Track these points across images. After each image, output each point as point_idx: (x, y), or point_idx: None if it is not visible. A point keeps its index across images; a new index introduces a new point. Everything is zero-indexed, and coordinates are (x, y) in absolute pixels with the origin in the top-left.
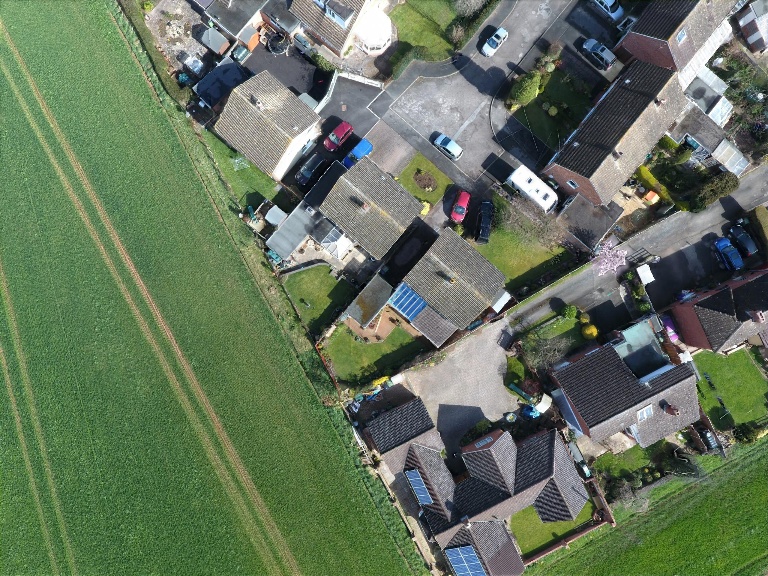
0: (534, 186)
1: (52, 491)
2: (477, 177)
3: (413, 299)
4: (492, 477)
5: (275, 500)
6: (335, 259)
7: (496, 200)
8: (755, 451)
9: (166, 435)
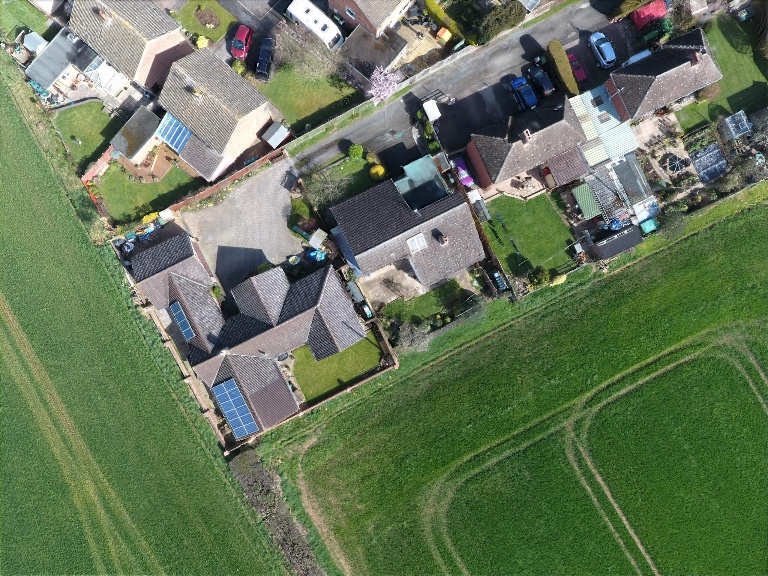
0: (312, 16)
1: None
2: (263, 15)
3: (179, 129)
4: (257, 309)
5: (42, 341)
6: (110, 97)
7: None
8: (557, 300)
9: None
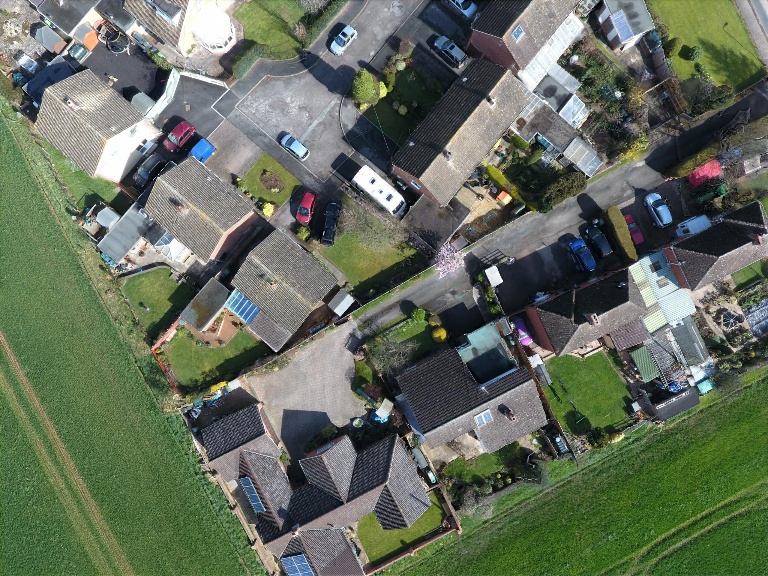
0: (377, 187)
1: None
2: (326, 178)
3: (249, 302)
4: (326, 484)
5: (111, 508)
6: (177, 262)
7: (345, 201)
8: (614, 456)
9: None
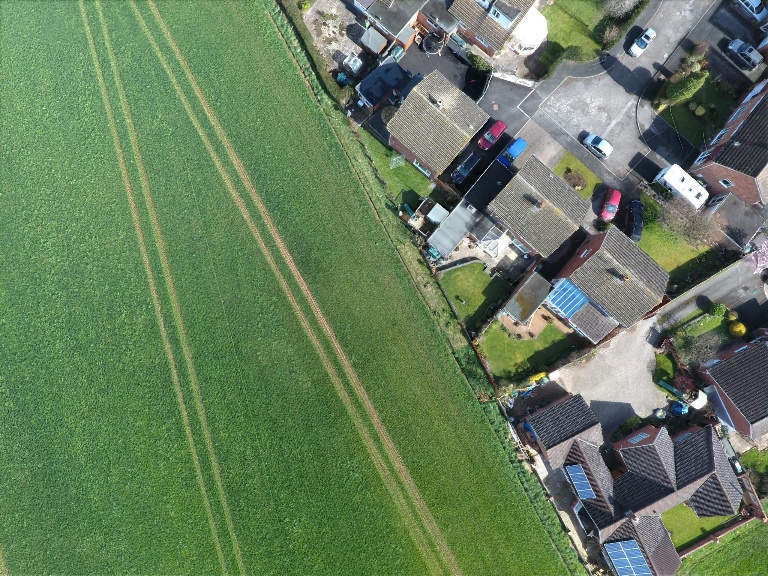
0: (687, 185)
1: (219, 485)
2: (624, 176)
3: (572, 296)
4: (653, 472)
5: (433, 494)
6: (488, 257)
7: (643, 199)
8: None
9: (328, 430)
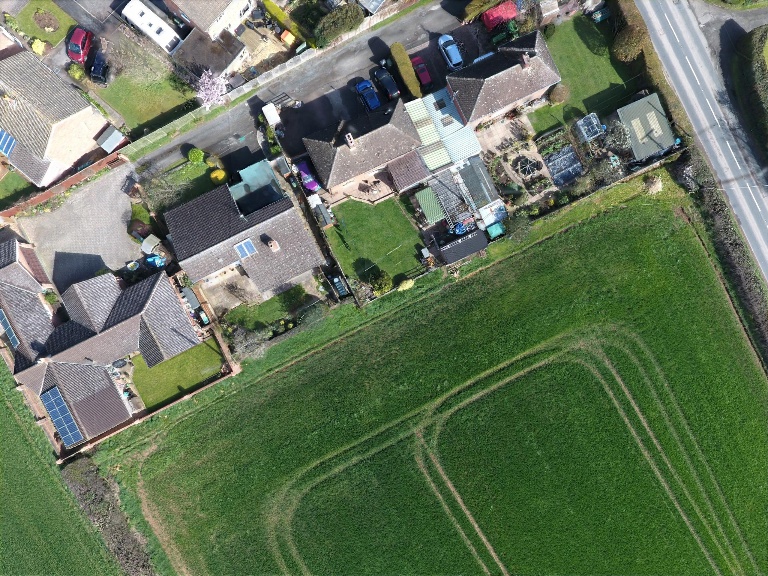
0: (146, 19)
1: None
2: (105, 18)
3: (7, 134)
4: (82, 316)
5: None
6: None
7: (123, 42)
8: (406, 305)
9: None
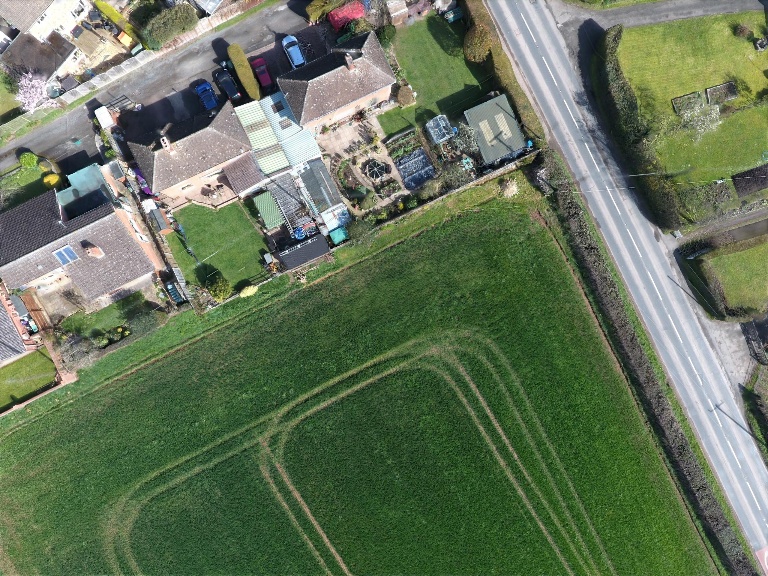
0: None
1: None
2: None
3: None
4: None
5: None
6: None
7: None
8: (251, 312)
9: None
